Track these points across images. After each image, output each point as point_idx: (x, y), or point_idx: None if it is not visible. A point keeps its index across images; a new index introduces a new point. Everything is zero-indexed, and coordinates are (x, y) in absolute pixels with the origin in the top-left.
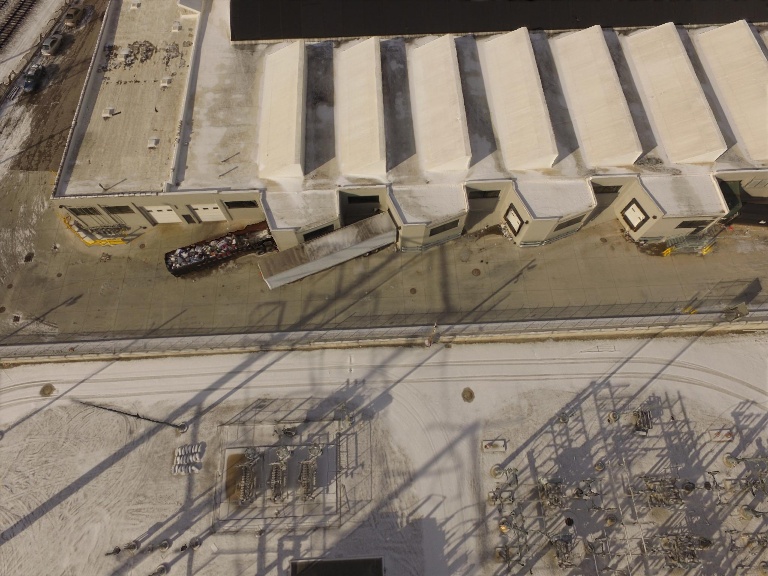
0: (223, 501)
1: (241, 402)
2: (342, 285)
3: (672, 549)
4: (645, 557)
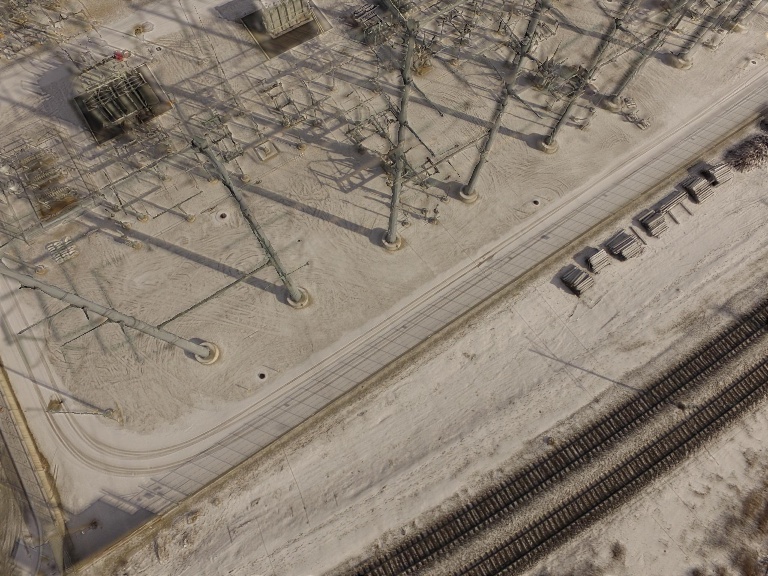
0: (80, 207)
1: (3, 241)
2: None
3: None
4: None
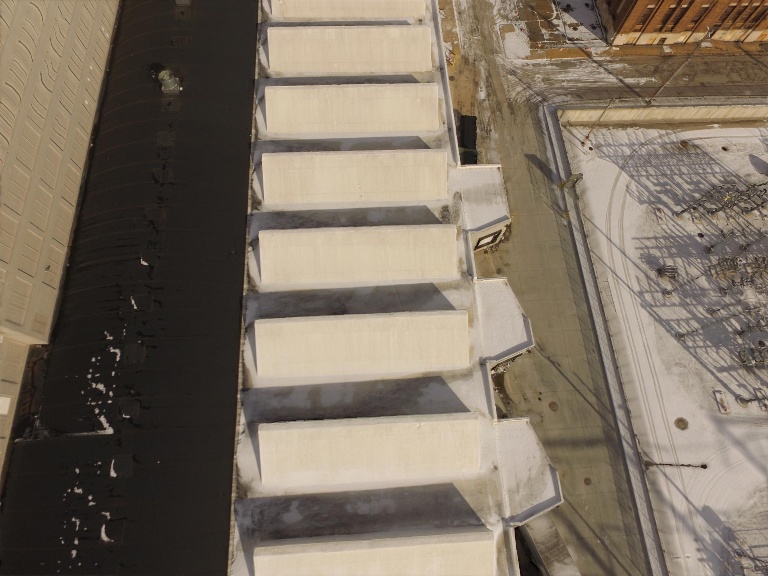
0: None
1: None
2: (595, 575)
3: (760, 271)
4: (767, 291)
